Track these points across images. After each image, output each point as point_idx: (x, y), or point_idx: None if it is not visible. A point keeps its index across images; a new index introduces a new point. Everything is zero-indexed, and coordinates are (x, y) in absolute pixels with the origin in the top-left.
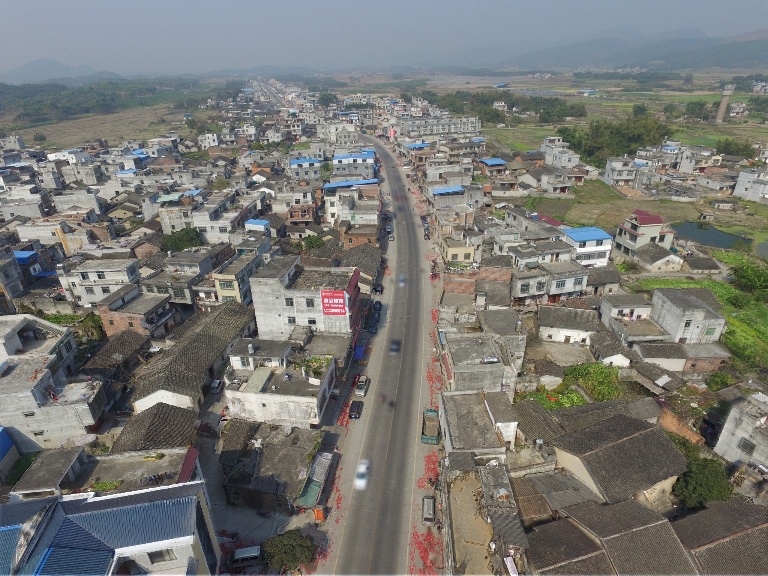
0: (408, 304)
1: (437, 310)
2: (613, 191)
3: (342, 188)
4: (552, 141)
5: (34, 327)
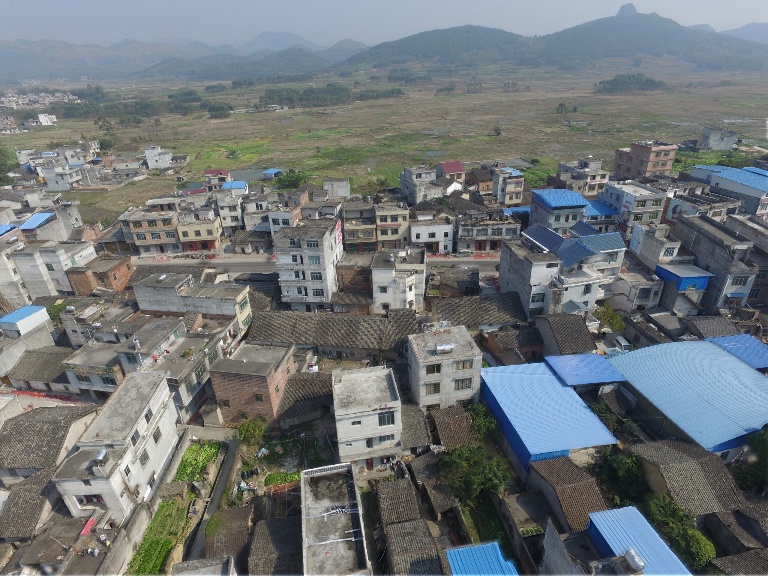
0: (257, 266)
1: (274, 256)
2: (82, 192)
3: None
4: None
5: None
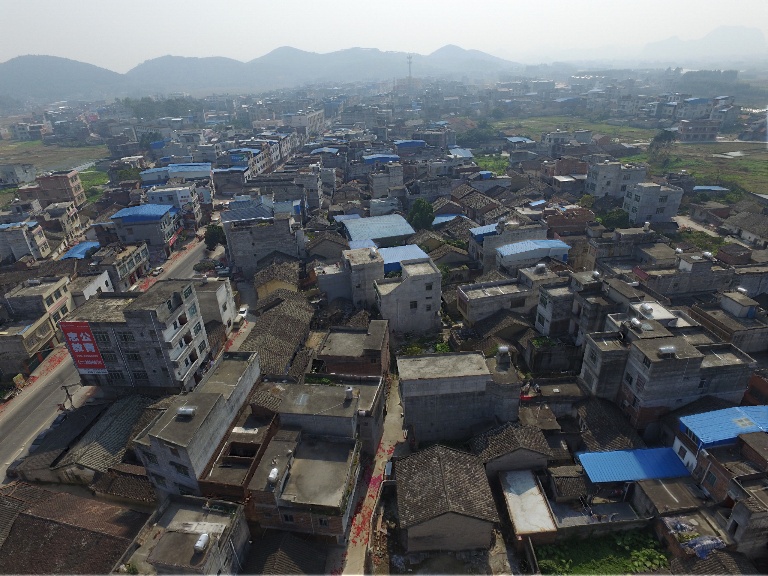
0: None
1: None
2: None
3: None
4: None
5: None
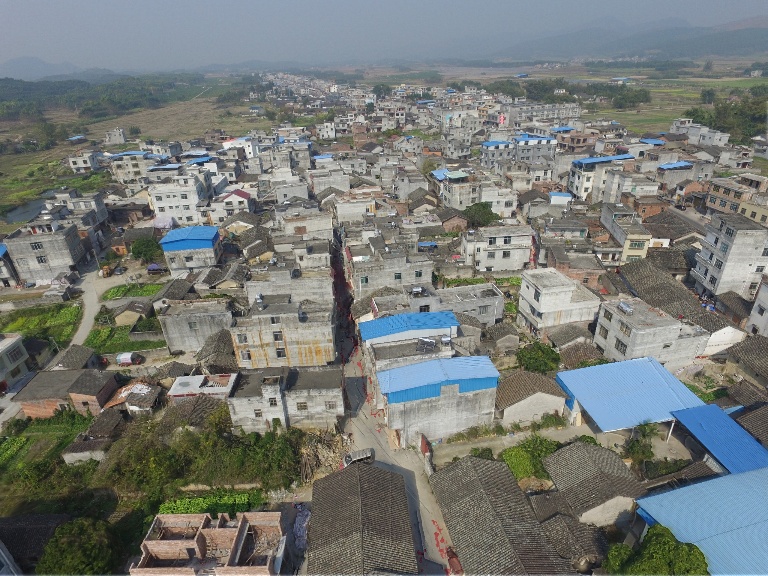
0: None
1: None
2: None
3: (602, 163)
4: (682, 123)
5: None
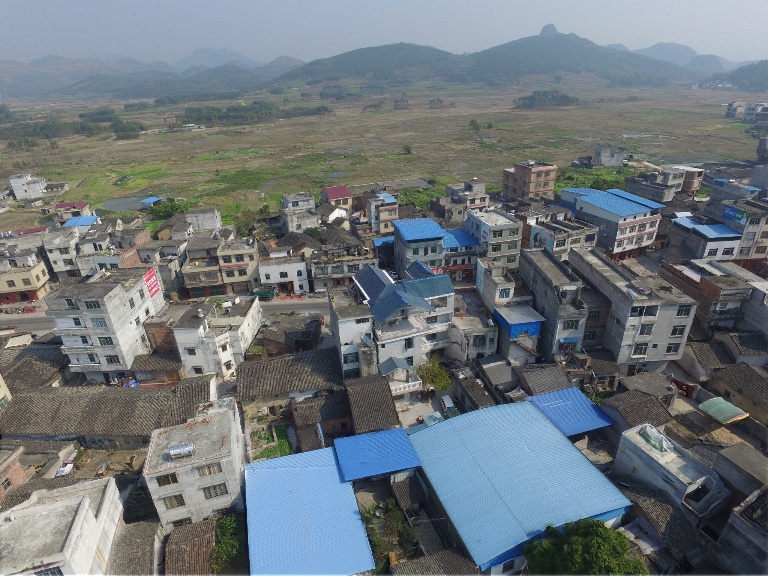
0: None
1: None
2: None
3: None
4: None
5: None
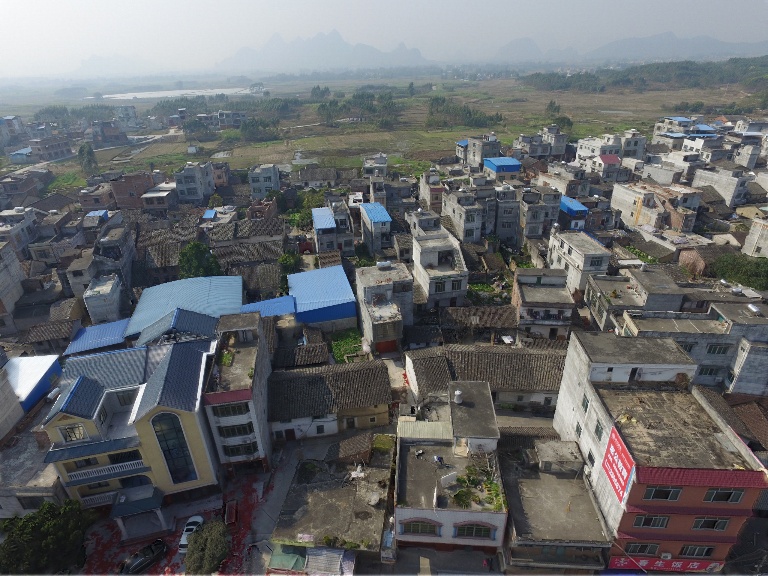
0: None
1: None
2: None
3: None
4: None
5: (454, 256)
